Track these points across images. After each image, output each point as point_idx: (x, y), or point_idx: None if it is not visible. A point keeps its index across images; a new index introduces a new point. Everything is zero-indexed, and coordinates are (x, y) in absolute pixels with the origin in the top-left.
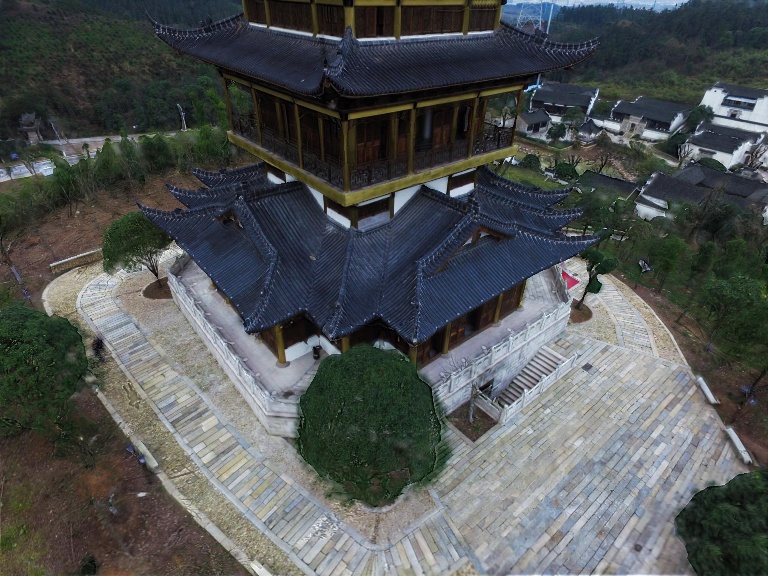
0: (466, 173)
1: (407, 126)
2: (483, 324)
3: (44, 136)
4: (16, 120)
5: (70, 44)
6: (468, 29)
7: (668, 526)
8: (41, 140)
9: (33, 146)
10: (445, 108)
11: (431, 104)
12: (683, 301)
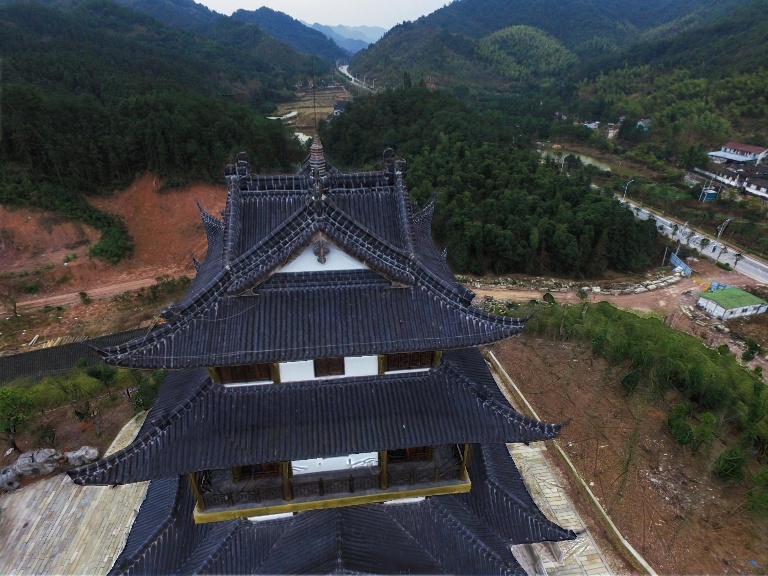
0: None
1: None
2: None
3: None
4: None
5: None
6: None
7: (2, 553)
8: None
9: None
10: None
11: None
12: None
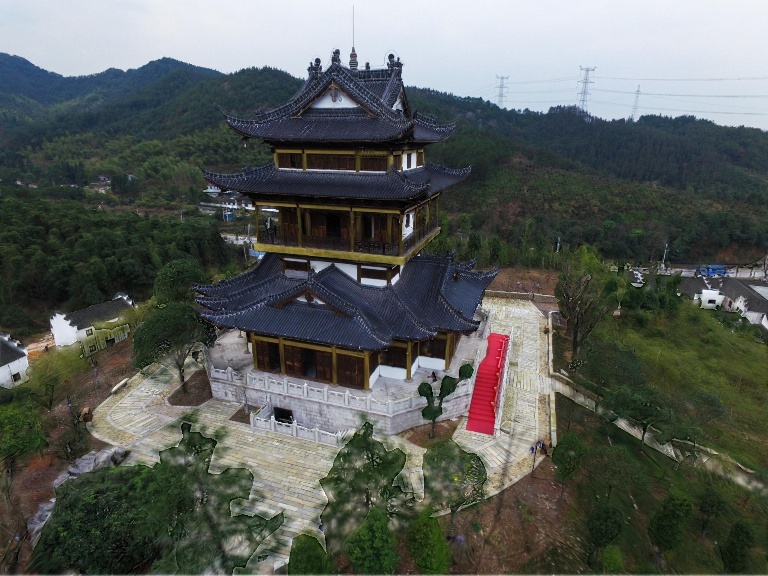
0: (377, 270)
1: (318, 221)
2: (322, 376)
3: None
4: None
5: (526, 187)
6: (361, 169)
7: None
8: None
9: None
10: (325, 213)
11: (311, 207)
12: (630, 563)
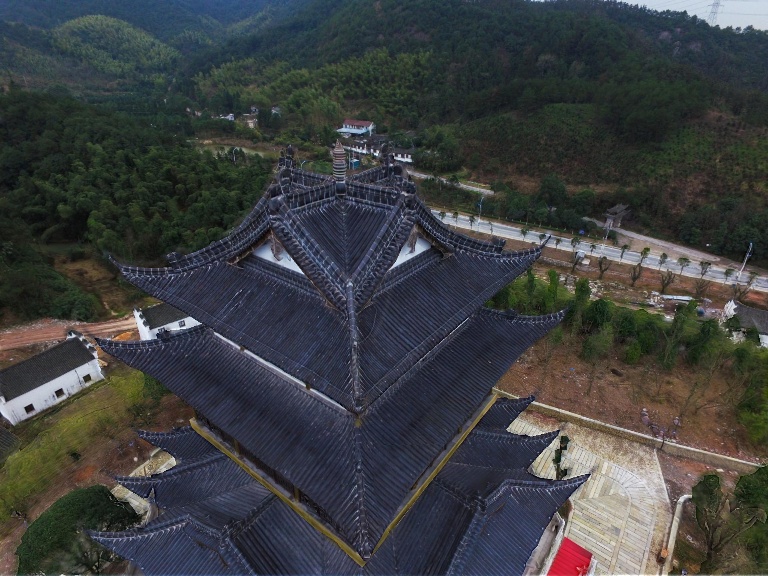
0: None
1: None
2: None
3: (623, 224)
4: (613, 206)
5: (720, 155)
6: None
7: None
8: (617, 227)
9: (602, 230)
10: None
11: None
12: None
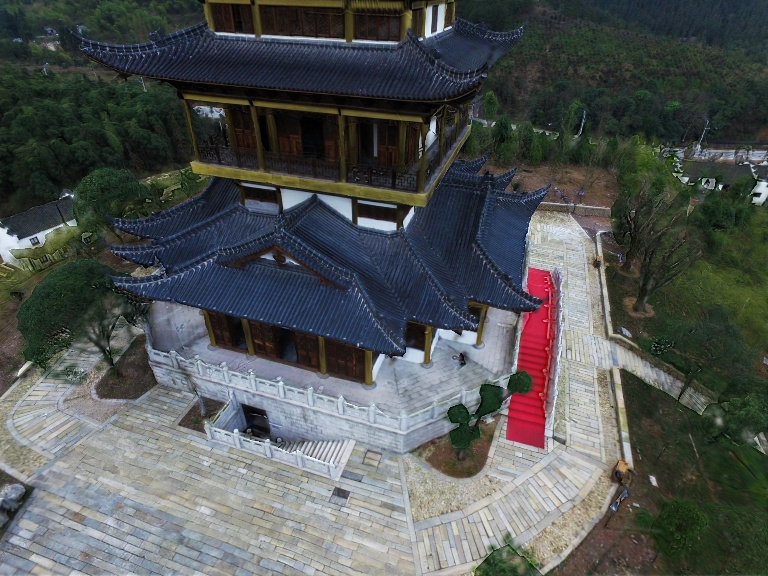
0: (383, 207)
1: (288, 127)
2: (305, 362)
3: (480, 115)
4: None
5: (549, 45)
6: (355, 36)
7: None
8: (476, 117)
9: None
10: (297, 116)
11: (272, 106)
12: None
